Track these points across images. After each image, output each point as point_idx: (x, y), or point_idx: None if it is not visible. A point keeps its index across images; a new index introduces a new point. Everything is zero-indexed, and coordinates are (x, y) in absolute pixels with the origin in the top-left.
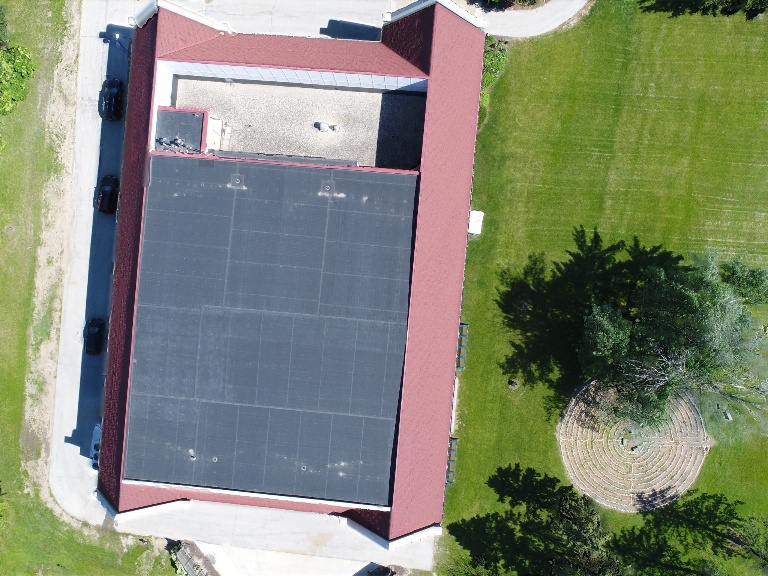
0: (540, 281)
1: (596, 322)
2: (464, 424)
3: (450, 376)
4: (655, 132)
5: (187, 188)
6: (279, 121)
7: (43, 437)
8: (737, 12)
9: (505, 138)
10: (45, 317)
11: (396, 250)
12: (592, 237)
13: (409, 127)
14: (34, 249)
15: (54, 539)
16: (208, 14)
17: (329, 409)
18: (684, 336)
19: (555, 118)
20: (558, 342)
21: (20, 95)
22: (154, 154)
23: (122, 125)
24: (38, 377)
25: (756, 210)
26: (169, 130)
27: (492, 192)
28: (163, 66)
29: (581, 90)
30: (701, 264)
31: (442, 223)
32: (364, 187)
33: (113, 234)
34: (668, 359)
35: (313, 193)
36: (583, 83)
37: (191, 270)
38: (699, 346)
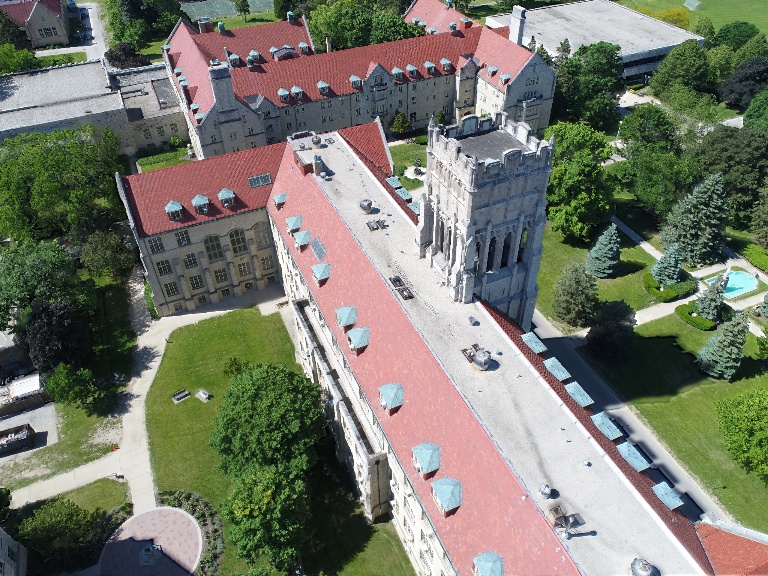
0: None
1: None
2: None
3: None
4: None
5: None
6: None
7: (99, 7)
8: None
9: None
10: None
11: None
12: None
13: None
14: None
15: (92, 1)
16: None
17: None
18: None
19: None
20: None
21: None
22: None
23: None
24: None
25: None
26: None
27: None
28: None
29: None
30: None
31: None
32: None
33: None
34: None
35: None
36: None
37: None
38: None
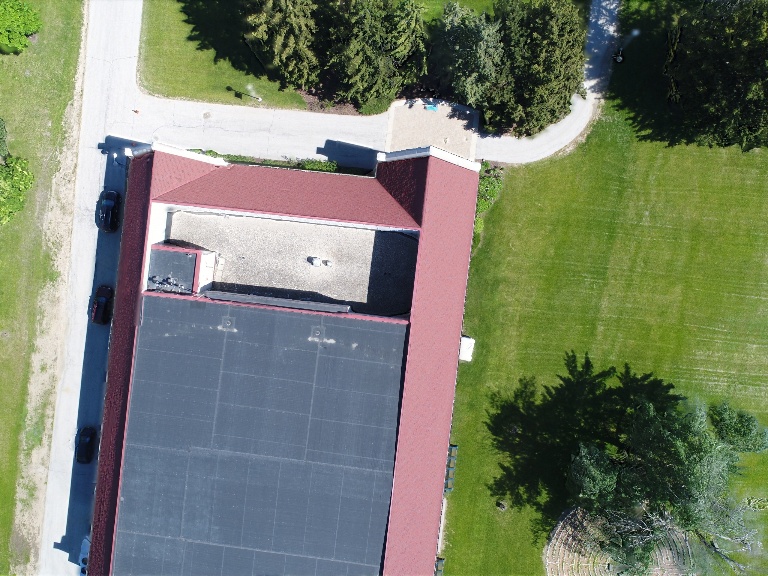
0: (530, 404)
1: (583, 465)
2: (451, 544)
3: (436, 514)
4: (648, 260)
5: (178, 329)
6: (272, 254)
7: (32, 542)
8: (733, 145)
9: (498, 263)
10: (37, 423)
11: (384, 398)
12: (583, 362)
13: (401, 264)
14: (28, 355)
15: None
16: (206, 129)
17: (314, 554)
18: (670, 490)
19: (549, 244)
20: (547, 465)
21: (18, 206)
22: (146, 294)
23: (118, 236)
24: (29, 482)
25: (748, 342)
26: (162, 269)
27: (484, 315)
28: (157, 207)
29: (575, 216)
30: (691, 393)
31: (431, 367)
32: (354, 334)
33: (107, 343)
34: (653, 515)
35: (303, 338)
36: (578, 210)
37: (180, 411)
38: (684, 505)
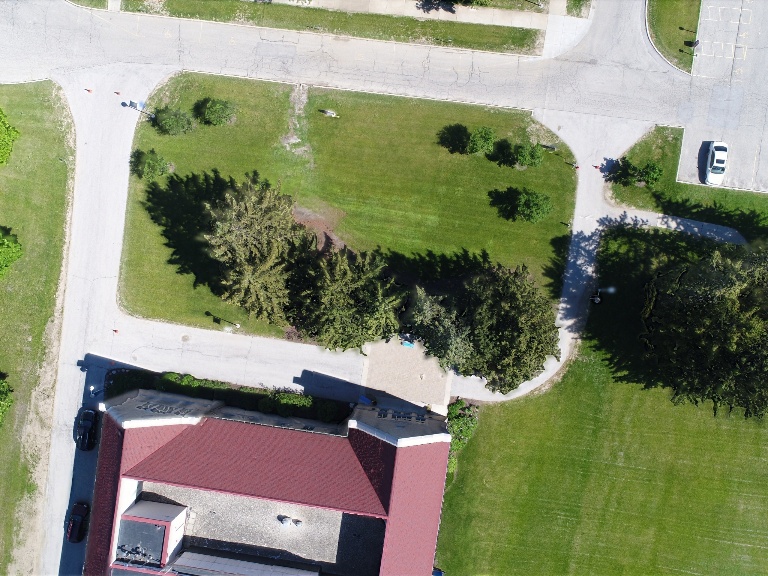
0: None
1: None
2: None
3: None
4: (622, 501)
5: None
6: (243, 510)
7: None
8: None
9: (472, 498)
10: None
11: None
12: None
13: (371, 527)
14: (4, 565)
15: None
16: (184, 352)
17: None
18: None
19: (523, 481)
20: None
21: None
22: (115, 567)
23: (96, 452)
24: None
25: None
26: (131, 538)
27: (457, 549)
28: (127, 480)
29: (550, 454)
30: None
31: None
32: None
33: (82, 558)
34: None
35: None
36: (552, 448)
37: None
38: None
